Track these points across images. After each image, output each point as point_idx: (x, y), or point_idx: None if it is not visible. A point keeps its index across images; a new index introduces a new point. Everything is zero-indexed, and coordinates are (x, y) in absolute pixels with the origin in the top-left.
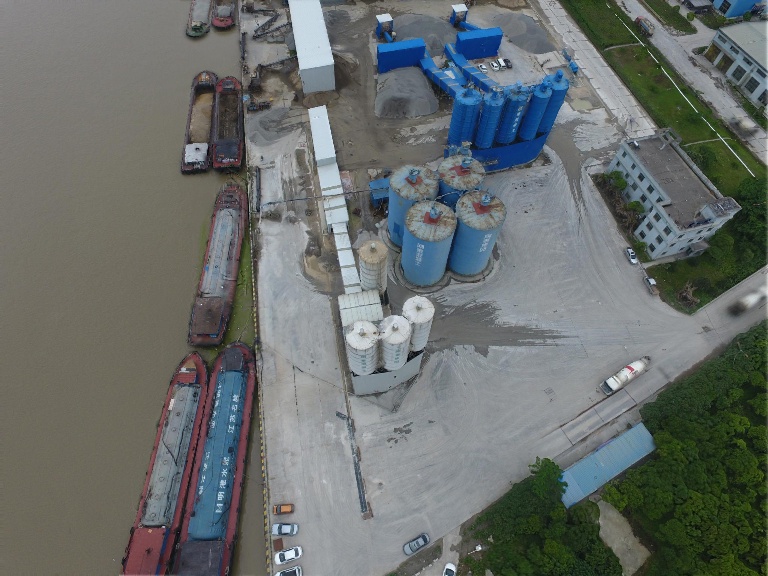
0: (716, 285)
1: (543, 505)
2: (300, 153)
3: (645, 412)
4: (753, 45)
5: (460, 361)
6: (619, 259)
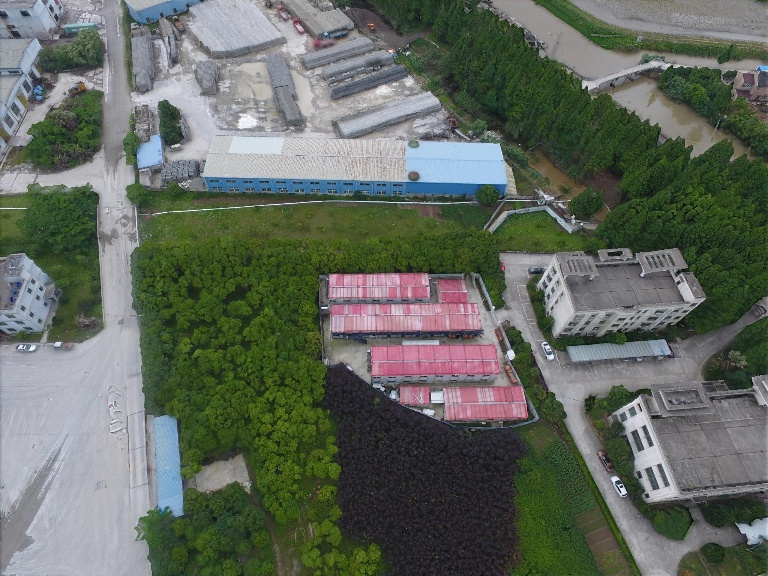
0: (93, 294)
1: (169, 540)
2: None
3: (147, 412)
4: None
5: (22, 574)
6: (23, 360)
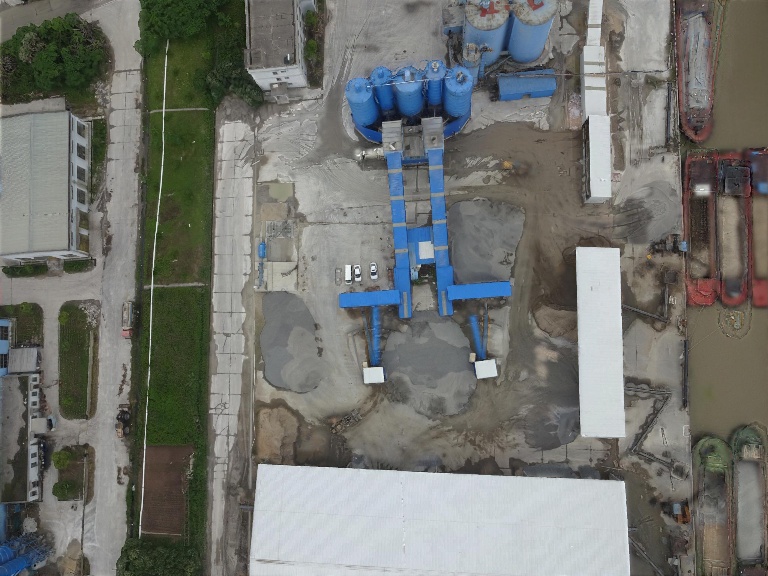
0: None
1: None
2: (620, 164)
3: None
4: (53, 208)
5: None
6: None
